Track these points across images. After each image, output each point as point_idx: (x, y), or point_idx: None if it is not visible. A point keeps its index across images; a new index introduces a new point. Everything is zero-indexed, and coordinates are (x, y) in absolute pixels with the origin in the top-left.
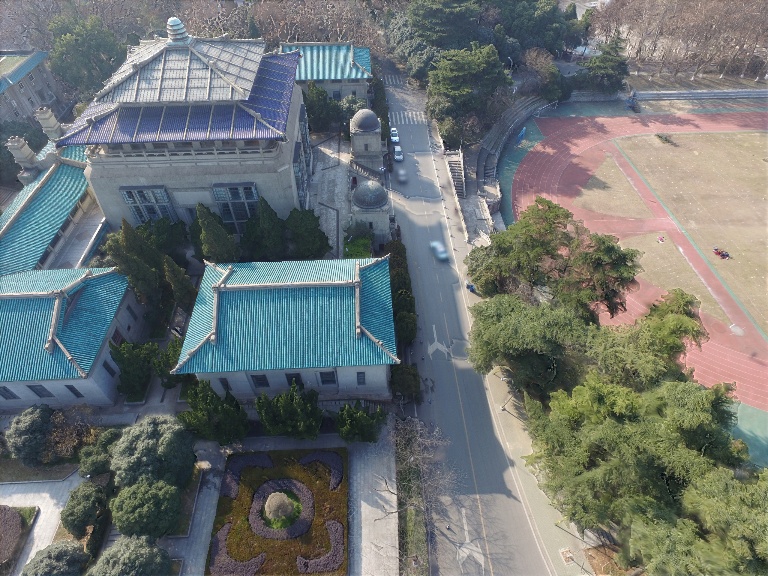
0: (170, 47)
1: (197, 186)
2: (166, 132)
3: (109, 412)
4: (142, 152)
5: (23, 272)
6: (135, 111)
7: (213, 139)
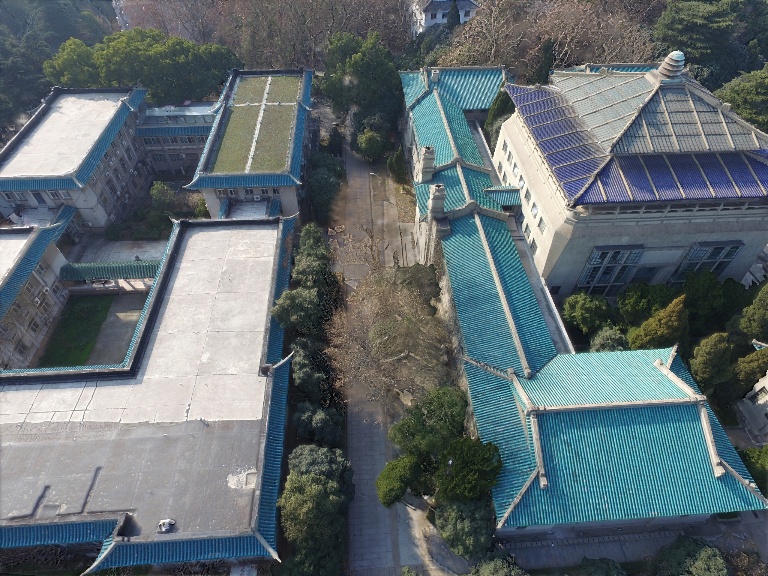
0: (665, 85)
1: (676, 245)
2: (687, 187)
3: (707, 532)
4: (641, 209)
5: (555, 358)
6: (634, 161)
7: (747, 196)
